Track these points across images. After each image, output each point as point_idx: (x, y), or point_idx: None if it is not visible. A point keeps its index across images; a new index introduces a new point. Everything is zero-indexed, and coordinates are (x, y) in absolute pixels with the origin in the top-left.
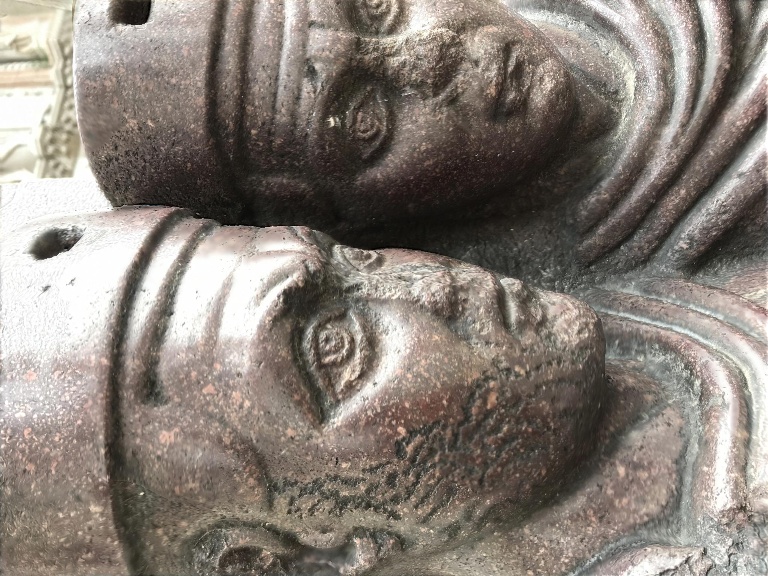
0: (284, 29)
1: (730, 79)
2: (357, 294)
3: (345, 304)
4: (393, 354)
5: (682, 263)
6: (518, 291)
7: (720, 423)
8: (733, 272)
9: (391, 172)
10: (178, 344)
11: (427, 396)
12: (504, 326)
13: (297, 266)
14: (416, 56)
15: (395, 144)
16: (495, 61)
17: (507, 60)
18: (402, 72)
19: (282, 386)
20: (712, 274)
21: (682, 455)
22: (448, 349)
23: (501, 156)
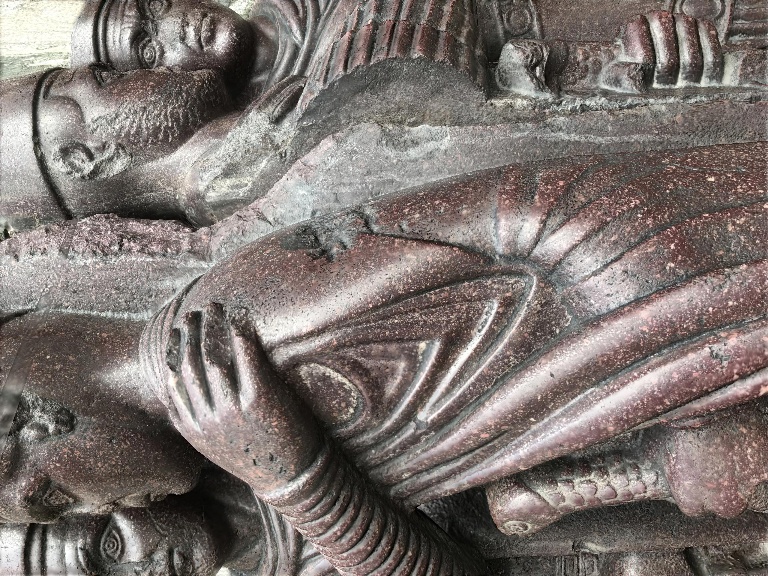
0: None
1: None
2: None
3: None
4: None
5: None
6: (181, 566)
7: (265, 570)
8: None
9: None
10: None
11: None
12: None
13: None
14: None
15: None
16: None
17: None
18: None
19: None
20: None
21: (259, 561)
22: None
23: None
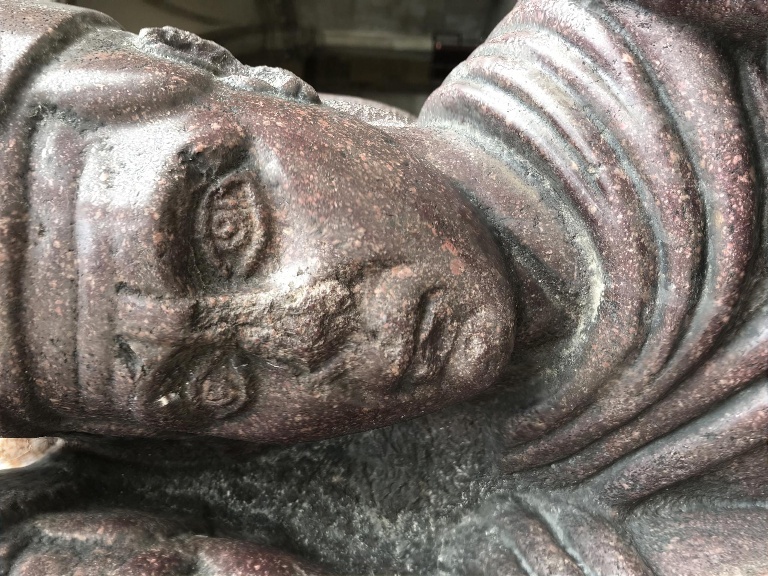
0: (78, 291)
1: (725, 330)
2: None
3: None
4: None
5: (619, 501)
6: None
7: None
8: (676, 523)
9: (257, 431)
10: None
11: None
12: None
13: None
14: (284, 330)
15: (260, 406)
16: (401, 333)
17: (421, 320)
18: (264, 345)
19: None
20: (652, 513)
21: None
22: None
23: (406, 416)
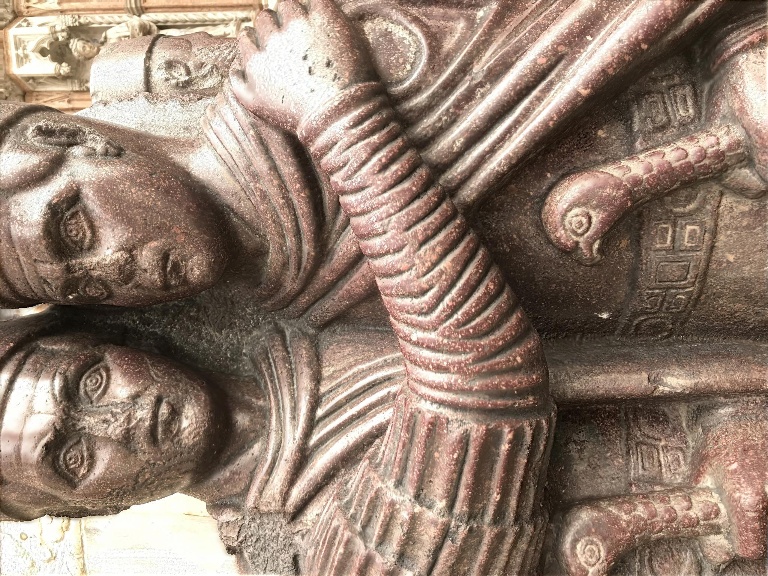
0: (21, 262)
1: (317, 257)
2: (84, 431)
3: (80, 434)
4: (101, 461)
5: (314, 326)
6: (166, 418)
7: (261, 468)
8: (339, 336)
9: None
10: (6, 465)
11: (117, 479)
12: (154, 442)
13: (50, 427)
14: (106, 272)
15: (116, 295)
16: (156, 270)
17: (166, 262)
18: None
19: (53, 481)
20: (333, 331)
21: (254, 470)
22: (124, 460)
23: (183, 296)
